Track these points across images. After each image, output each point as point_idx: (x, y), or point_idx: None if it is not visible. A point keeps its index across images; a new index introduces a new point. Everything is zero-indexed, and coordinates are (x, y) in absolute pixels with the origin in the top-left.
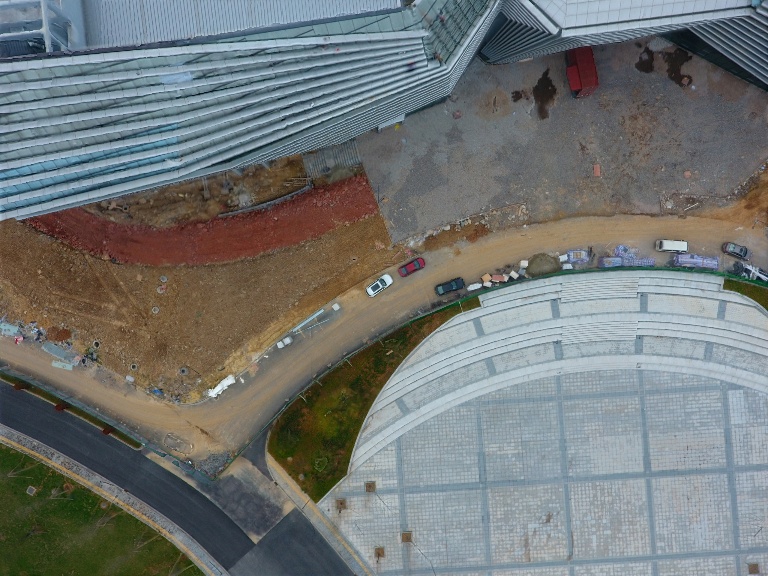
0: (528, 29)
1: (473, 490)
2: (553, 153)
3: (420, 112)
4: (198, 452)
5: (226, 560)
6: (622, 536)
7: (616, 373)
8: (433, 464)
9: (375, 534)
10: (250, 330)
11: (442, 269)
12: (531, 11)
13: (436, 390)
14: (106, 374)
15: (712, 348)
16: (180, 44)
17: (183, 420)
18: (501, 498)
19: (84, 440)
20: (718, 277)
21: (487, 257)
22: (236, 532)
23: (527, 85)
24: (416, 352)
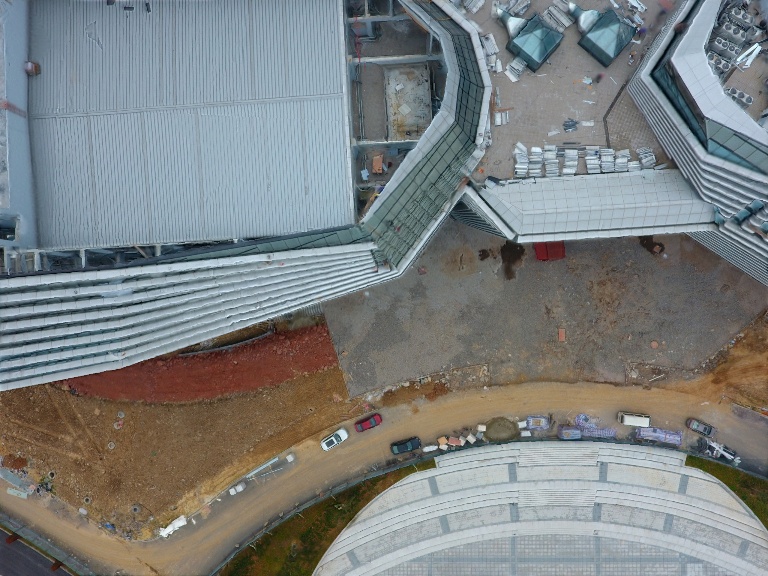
0: (487, 224)
1: None
2: (518, 315)
3: None
4: None
5: None
6: None
7: (572, 538)
8: None
9: None
10: (204, 473)
11: (399, 426)
12: (488, 215)
13: (388, 544)
14: (60, 505)
15: (672, 520)
16: (119, 266)
17: (133, 556)
18: None
19: (34, 570)
20: (680, 452)
21: (445, 417)
22: None
23: (495, 244)
24: (369, 507)
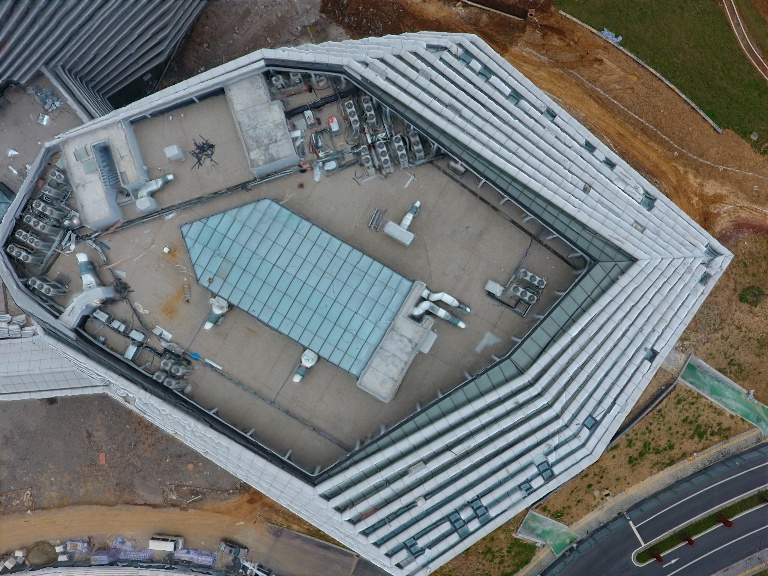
0: None
1: None
2: (60, 439)
3: None
4: None
5: None
6: None
7: None
8: None
9: None
10: None
11: None
12: None
13: None
14: None
15: None
16: None
17: None
18: None
19: None
20: (215, 572)
21: None
22: None
23: None
24: None
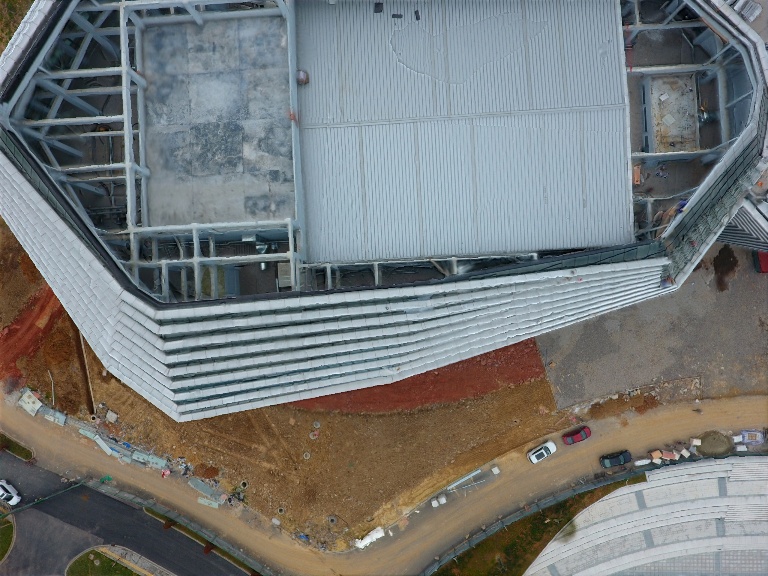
0: (751, 237)
1: None
2: (731, 327)
3: None
4: None
5: None
6: None
7: None
8: None
9: None
10: (403, 484)
11: (608, 439)
12: (765, 228)
13: (590, 558)
14: (252, 515)
15: None
16: (434, 282)
17: (327, 568)
18: None
19: None
20: None
21: (656, 430)
22: None
23: (708, 255)
24: (574, 520)
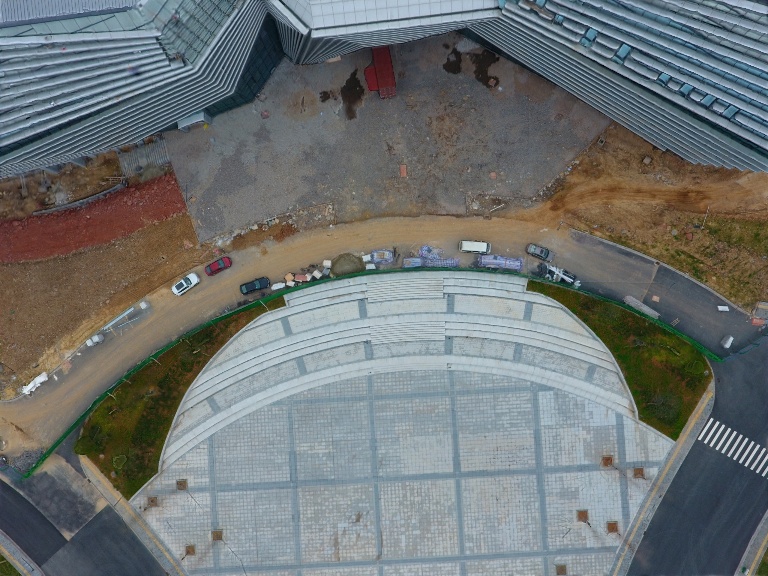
0: (290, 29)
1: (284, 489)
2: (360, 153)
3: (229, 112)
4: (12, 449)
5: (39, 556)
6: (431, 536)
7: (427, 373)
8: (245, 463)
9: (186, 532)
10: (62, 328)
11: (249, 268)
12: (282, 11)
13: (247, 389)
14: None
15: (521, 349)
16: None
17: None
18: (311, 497)
19: None
20: (522, 278)
21: (293, 257)
22: (49, 529)
23: (335, 85)
24: (224, 351)
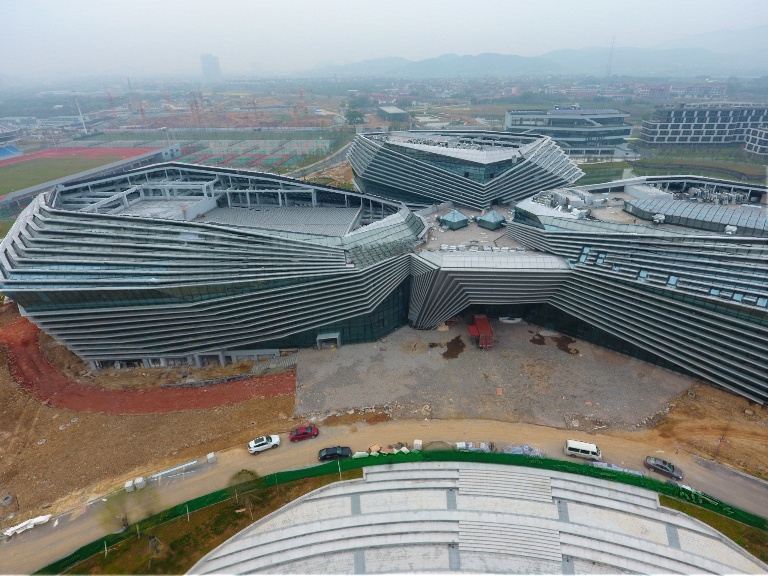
0: (424, 276)
1: None
2: (459, 377)
3: (355, 344)
4: None
5: None
6: None
7: None
8: None
9: None
10: (111, 470)
11: (334, 441)
12: (423, 262)
13: None
14: None
15: None
16: None
17: None
18: None
19: None
20: (649, 492)
21: (382, 437)
22: None
23: (442, 341)
24: (272, 519)
